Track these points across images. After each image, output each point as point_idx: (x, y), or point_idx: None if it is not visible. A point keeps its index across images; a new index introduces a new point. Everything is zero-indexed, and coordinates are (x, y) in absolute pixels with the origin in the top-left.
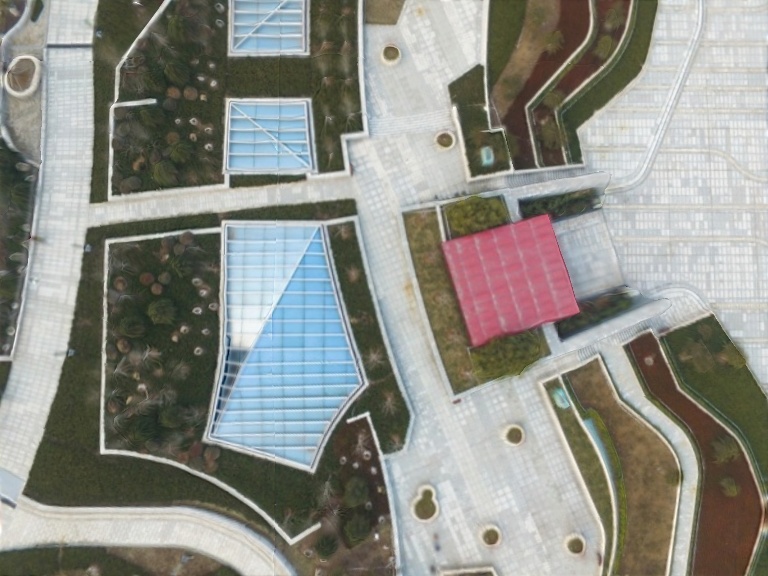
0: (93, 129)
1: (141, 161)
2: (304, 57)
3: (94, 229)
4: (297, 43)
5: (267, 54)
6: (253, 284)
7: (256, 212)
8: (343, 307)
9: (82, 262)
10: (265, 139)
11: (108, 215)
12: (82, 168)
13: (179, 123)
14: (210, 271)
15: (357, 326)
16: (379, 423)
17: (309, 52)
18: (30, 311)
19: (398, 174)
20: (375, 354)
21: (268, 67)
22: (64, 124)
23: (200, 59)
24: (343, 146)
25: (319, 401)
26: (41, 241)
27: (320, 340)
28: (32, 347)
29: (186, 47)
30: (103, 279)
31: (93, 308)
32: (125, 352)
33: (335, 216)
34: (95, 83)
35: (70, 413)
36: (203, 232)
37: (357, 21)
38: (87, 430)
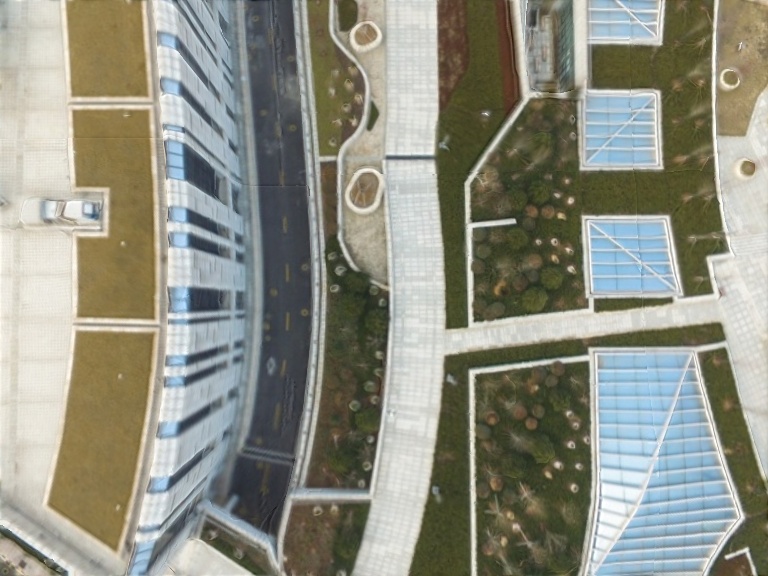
0: (442, 248)
1: (502, 285)
2: (659, 172)
3: (452, 357)
4: (651, 156)
5: (620, 168)
6: (628, 416)
7: (623, 338)
8: (716, 437)
9: (442, 392)
10: (628, 260)
11: (466, 342)
12: (434, 290)
13: (541, 244)
14: (583, 403)
15: (732, 458)
16: (760, 559)
17: (663, 166)
18: (388, 445)
19: (762, 296)
20: (753, 487)
21: (624, 183)
22: (410, 242)
23: (554, 174)
24: (710, 268)
25: (698, 538)
26: (397, 370)
27: (699, 474)
28: (391, 484)
29: (544, 163)
30: (468, 412)
31: (457, 442)
32: (498, 490)
33: (705, 342)
34: (441, 198)
35: (437, 554)
36: (572, 361)
37: (712, 134)
38: (456, 572)
